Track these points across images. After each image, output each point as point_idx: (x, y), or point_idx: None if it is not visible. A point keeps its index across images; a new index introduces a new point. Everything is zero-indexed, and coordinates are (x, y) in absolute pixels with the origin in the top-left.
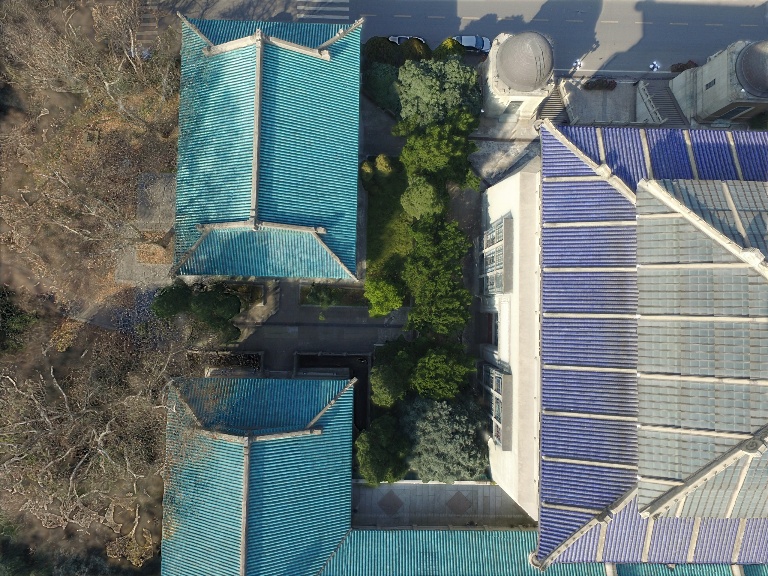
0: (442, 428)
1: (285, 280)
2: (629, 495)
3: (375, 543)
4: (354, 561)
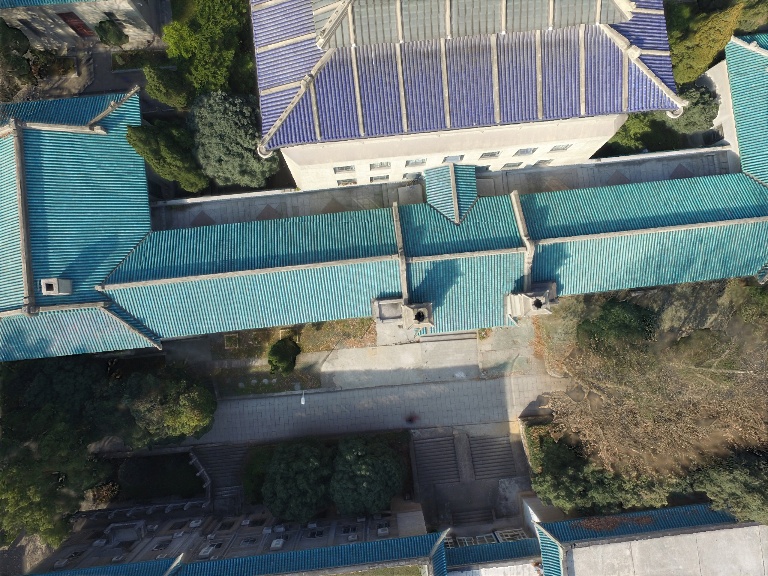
0: (216, 110)
1: (97, 51)
2: (324, 54)
3: (174, 238)
4: (152, 254)
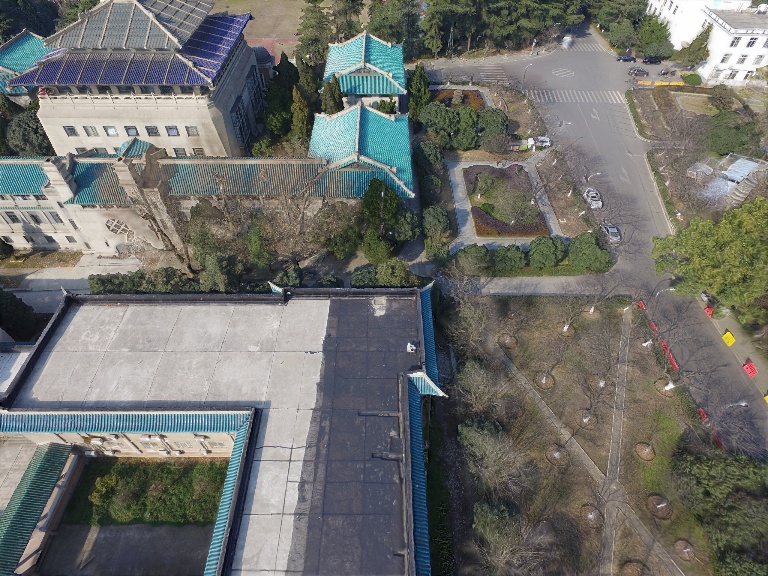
0: None
1: None
2: None
3: None
4: None
